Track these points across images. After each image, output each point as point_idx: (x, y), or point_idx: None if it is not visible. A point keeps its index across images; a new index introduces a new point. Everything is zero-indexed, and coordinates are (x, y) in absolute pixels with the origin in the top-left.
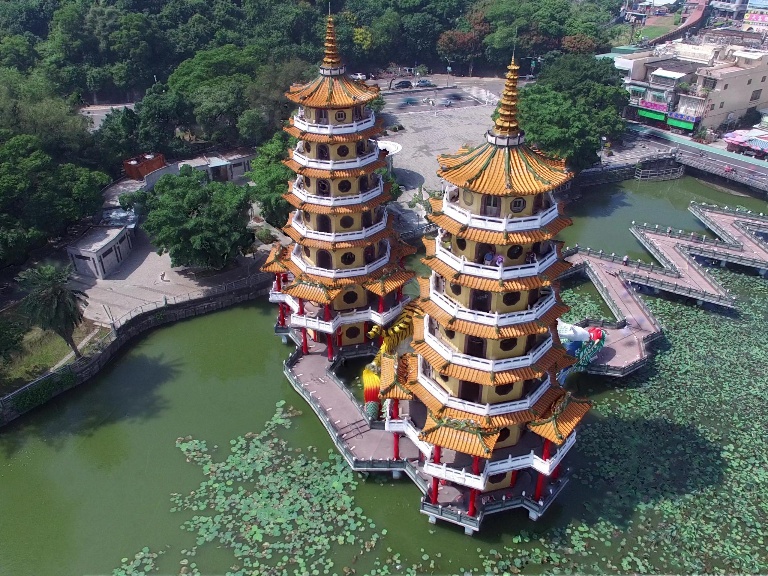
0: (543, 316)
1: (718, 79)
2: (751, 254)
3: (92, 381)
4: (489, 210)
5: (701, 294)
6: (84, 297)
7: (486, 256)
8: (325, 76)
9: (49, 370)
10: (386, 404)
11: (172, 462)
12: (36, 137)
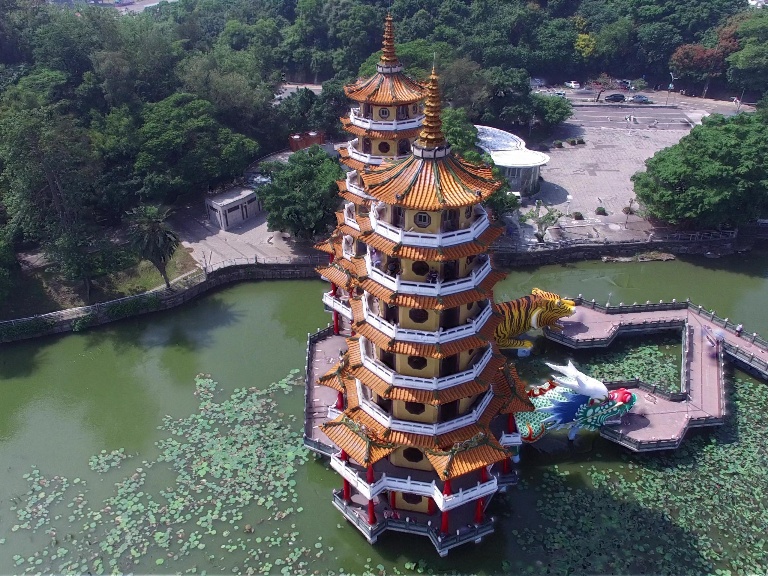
0: (451, 343)
1: None
2: None
3: (174, 310)
4: (400, 220)
5: None
6: (174, 238)
7: (389, 265)
8: (379, 73)
9: (145, 292)
10: None
11: (184, 391)
12: (210, 103)
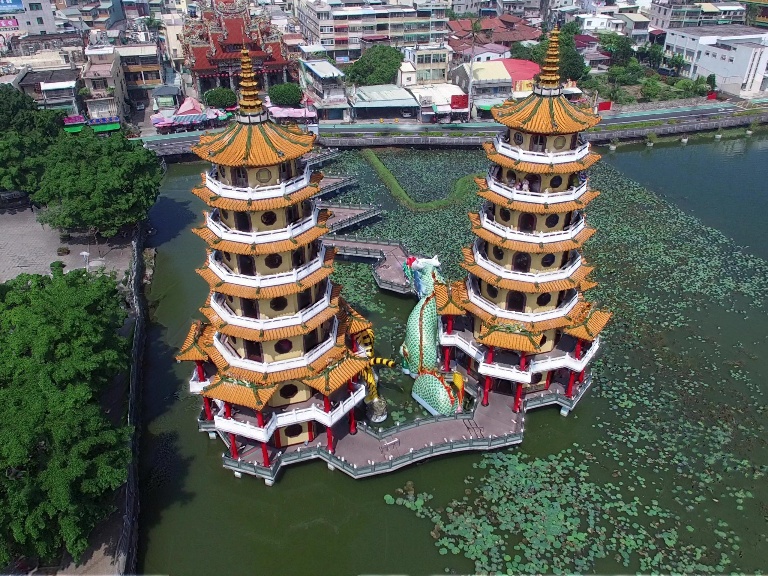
0: None
1: (109, 77)
2: (324, 183)
3: None
4: None
5: (364, 215)
6: None
7: (579, 179)
8: (261, 123)
9: None
10: (446, 401)
11: None
12: None
